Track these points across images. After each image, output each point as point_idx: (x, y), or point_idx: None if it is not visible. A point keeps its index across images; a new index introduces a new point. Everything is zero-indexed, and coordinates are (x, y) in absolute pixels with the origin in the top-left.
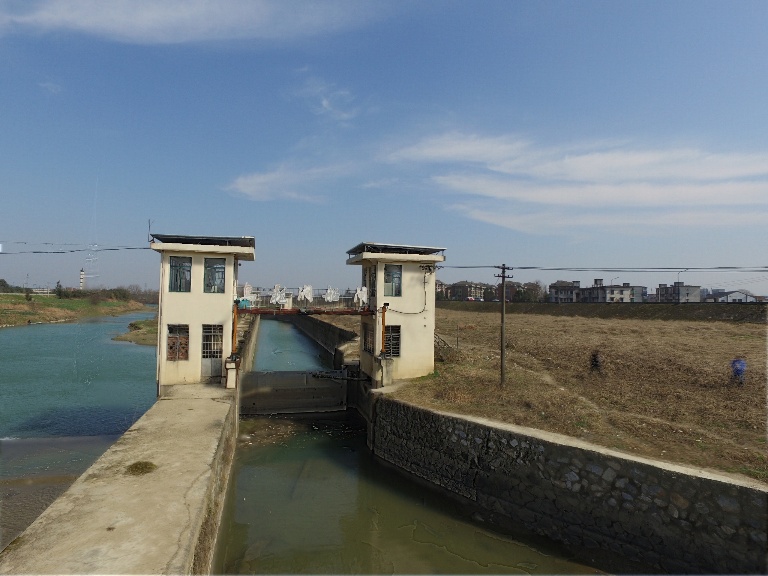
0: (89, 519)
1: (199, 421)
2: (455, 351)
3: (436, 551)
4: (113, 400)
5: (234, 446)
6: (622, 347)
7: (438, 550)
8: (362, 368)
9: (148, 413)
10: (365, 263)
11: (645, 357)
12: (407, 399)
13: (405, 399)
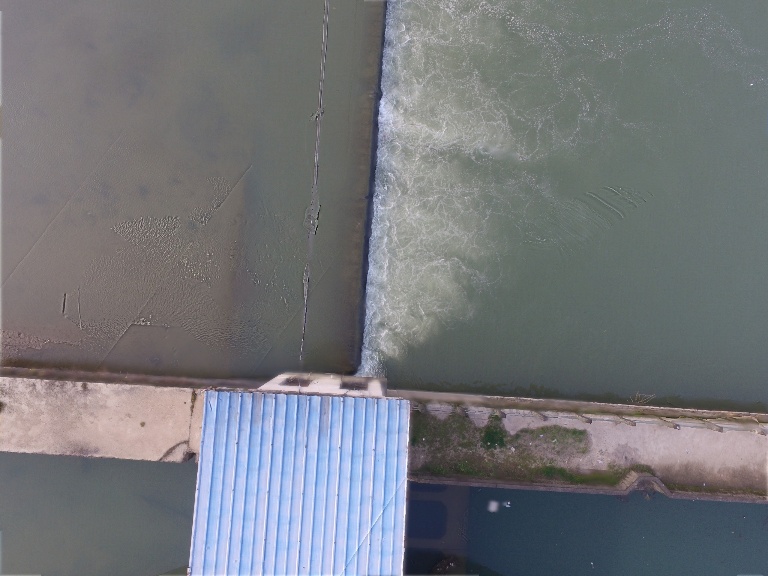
0: None
1: (97, 435)
2: None
3: (34, 574)
4: (547, 274)
5: None
6: None
7: (34, 575)
8: None
9: (138, 389)
10: None
11: None
12: None
13: None
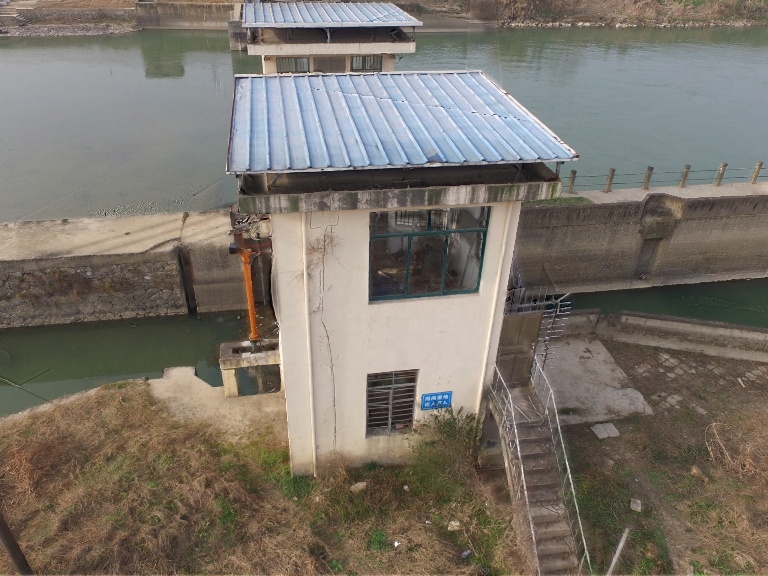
0: None
1: (73, 244)
2: (530, 563)
3: None
4: None
5: (228, 306)
6: None
7: None
8: None
9: (126, 217)
10: None
11: None
12: (76, 402)
13: (79, 399)
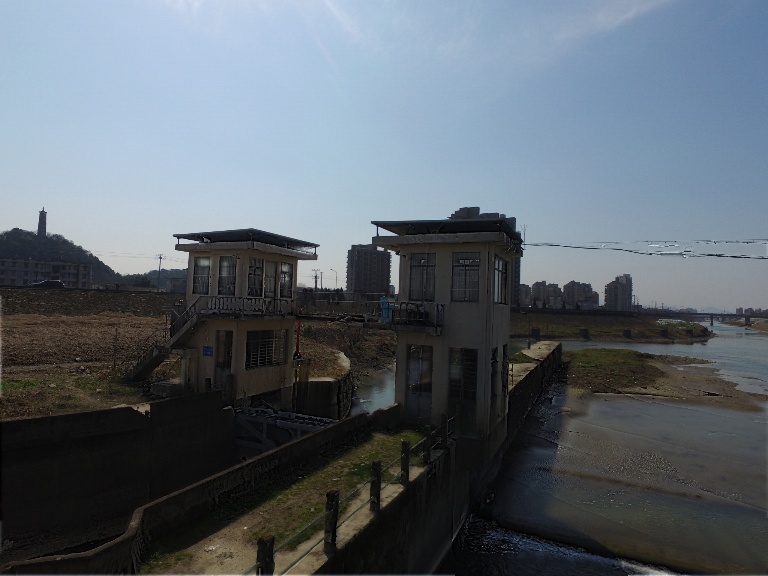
0: (515, 370)
1: None
2: None
3: None
4: None
5: None
6: (6, 341)
7: None
8: (250, 393)
9: None
10: (267, 254)
11: (91, 342)
12: None
13: (340, 373)
